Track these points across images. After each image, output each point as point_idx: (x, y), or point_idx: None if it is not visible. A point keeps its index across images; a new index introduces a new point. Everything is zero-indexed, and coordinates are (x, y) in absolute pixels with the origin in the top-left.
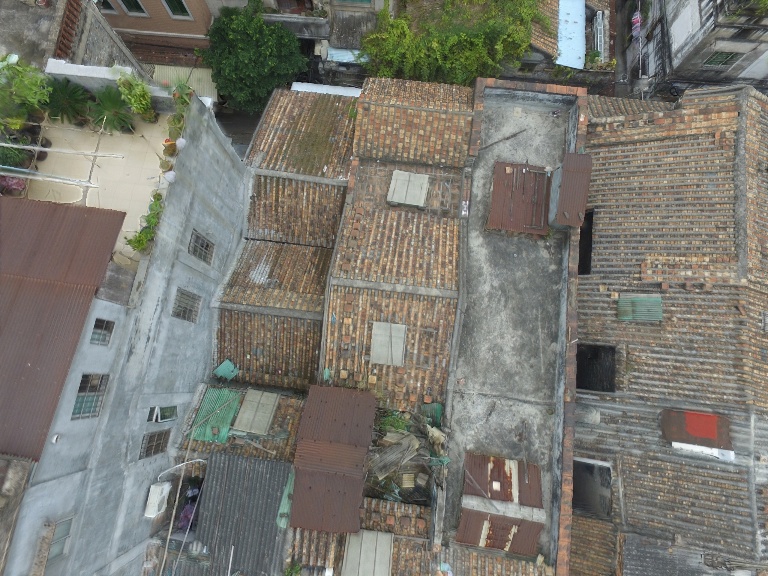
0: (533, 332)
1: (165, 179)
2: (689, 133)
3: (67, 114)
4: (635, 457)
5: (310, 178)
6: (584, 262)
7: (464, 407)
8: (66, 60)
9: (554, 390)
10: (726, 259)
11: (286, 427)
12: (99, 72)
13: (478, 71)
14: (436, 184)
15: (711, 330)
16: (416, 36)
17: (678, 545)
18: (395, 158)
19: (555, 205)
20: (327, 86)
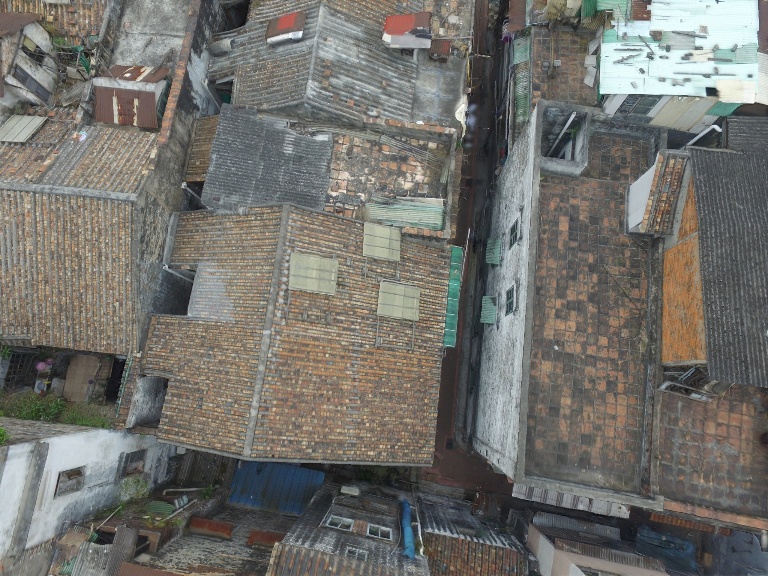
0: None
1: None
2: None
3: None
4: (250, 64)
5: None
6: None
7: (127, 43)
8: None
9: None
10: None
11: None
12: None
13: None
14: None
15: None
16: None
17: (263, 109)
18: None
19: None
20: None
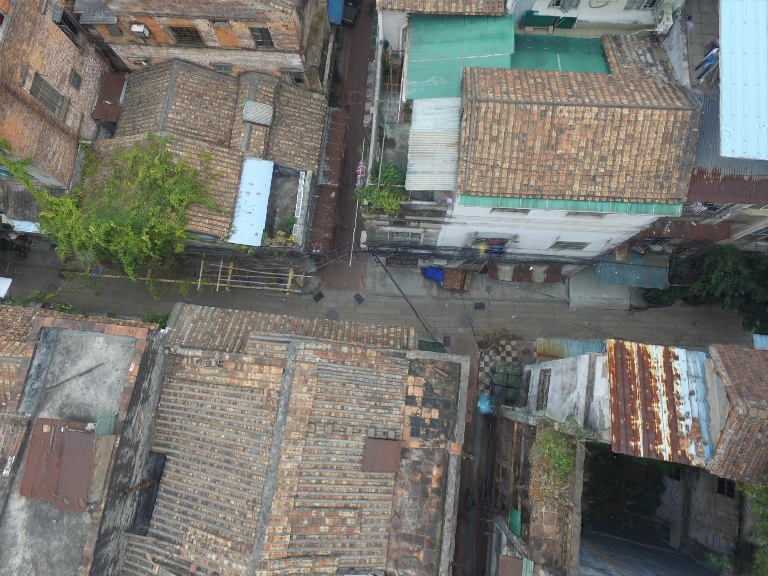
0: None
1: None
2: (245, 384)
3: None
4: None
5: None
6: None
7: None
8: None
9: None
10: (243, 548)
11: None
12: None
13: None
14: (1, 426)
15: None
16: (81, 216)
17: None
18: None
19: None
20: None
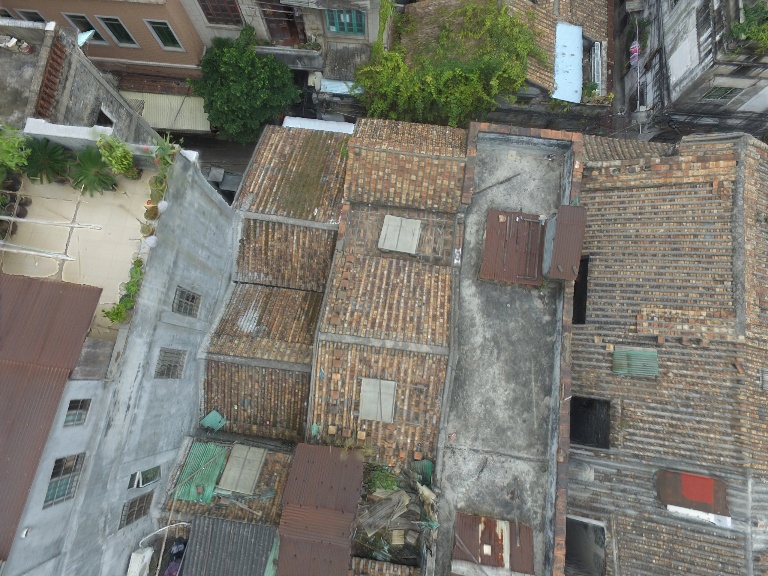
0: (526, 385)
1: (146, 243)
2: (686, 181)
3: (46, 174)
4: (630, 518)
5: (300, 222)
6: (579, 310)
7: (455, 463)
8: (49, 109)
9: (547, 446)
10: (723, 314)
11: (273, 485)
12: (79, 132)
13: (473, 105)
14: (428, 229)
15: (708, 388)
16: (410, 69)
17: None
18: (387, 203)
19: (549, 257)
20: (320, 121)
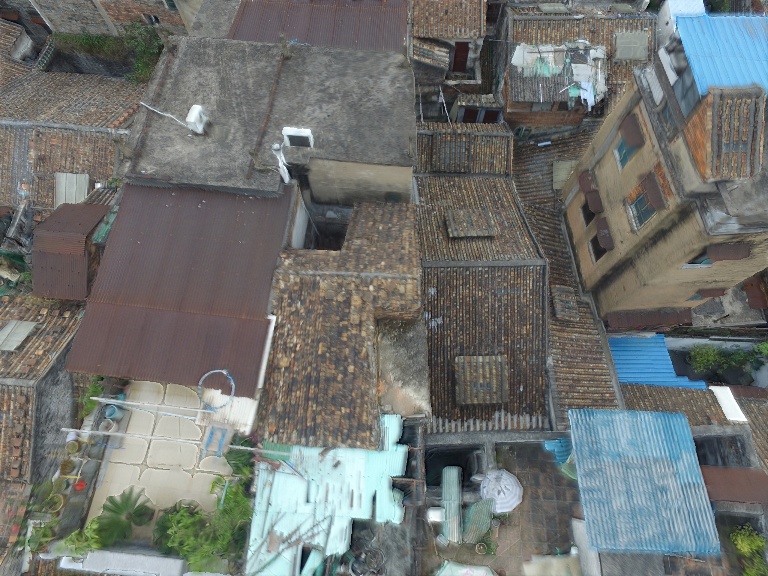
0: None
1: (80, 435)
2: None
3: None
4: None
5: None
6: None
7: None
8: None
9: None
10: None
11: None
12: (120, 562)
13: None
14: None
15: None
16: None
17: None
18: None
19: None
20: None
